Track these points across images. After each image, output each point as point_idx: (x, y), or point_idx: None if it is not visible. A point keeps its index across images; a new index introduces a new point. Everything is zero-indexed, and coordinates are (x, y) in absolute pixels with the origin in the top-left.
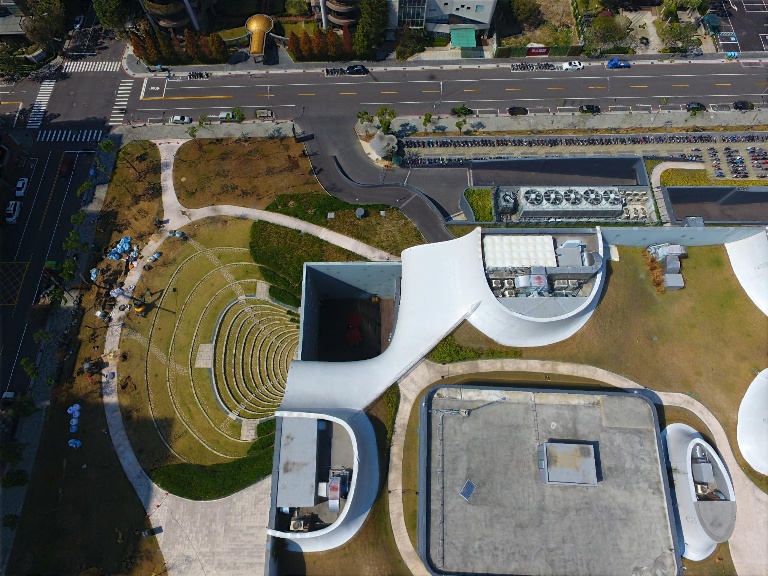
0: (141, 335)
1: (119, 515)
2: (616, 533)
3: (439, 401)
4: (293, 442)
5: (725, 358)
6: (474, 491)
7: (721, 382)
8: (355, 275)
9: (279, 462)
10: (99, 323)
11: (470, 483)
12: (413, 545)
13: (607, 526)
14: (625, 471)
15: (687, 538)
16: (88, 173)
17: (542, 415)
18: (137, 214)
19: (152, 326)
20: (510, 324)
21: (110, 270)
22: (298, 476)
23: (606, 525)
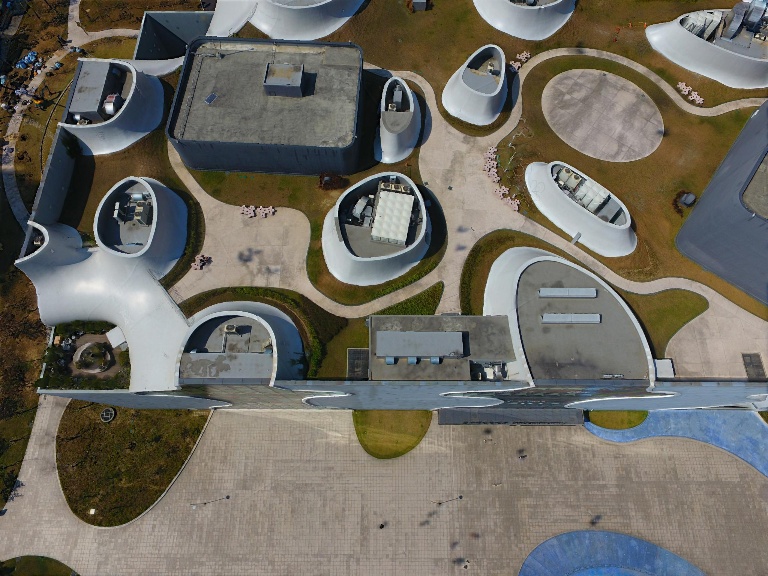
0: (39, 123)
1: (6, 244)
2: (315, 123)
3: (202, 50)
4: (88, 76)
5: (451, 52)
6: (215, 99)
7: (442, 65)
8: (194, 33)
9: (75, 86)
10: (4, 114)
11: (213, 95)
12: (181, 159)
13: (309, 119)
14: (332, 90)
15: (382, 146)
16: (6, 7)
17: (278, 58)
18: (45, 36)
19: (49, 117)
20: (277, 18)
21: (17, 76)
22: (88, 95)
23: (309, 119)
